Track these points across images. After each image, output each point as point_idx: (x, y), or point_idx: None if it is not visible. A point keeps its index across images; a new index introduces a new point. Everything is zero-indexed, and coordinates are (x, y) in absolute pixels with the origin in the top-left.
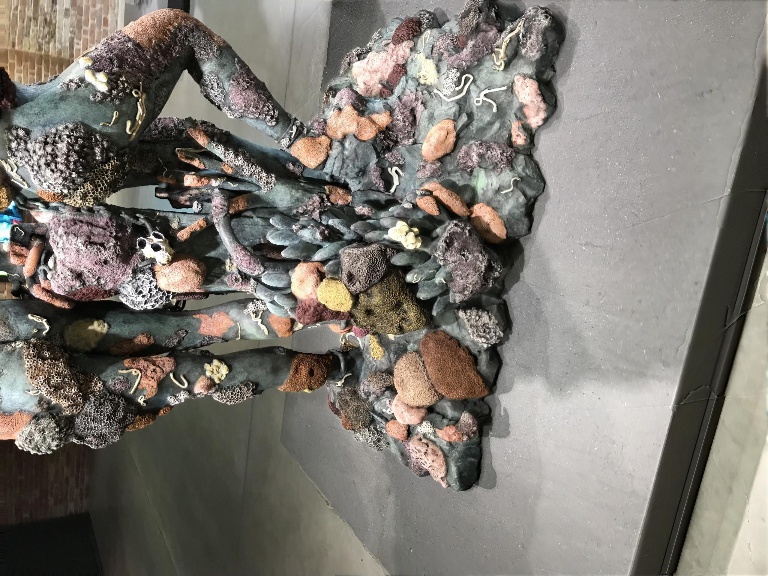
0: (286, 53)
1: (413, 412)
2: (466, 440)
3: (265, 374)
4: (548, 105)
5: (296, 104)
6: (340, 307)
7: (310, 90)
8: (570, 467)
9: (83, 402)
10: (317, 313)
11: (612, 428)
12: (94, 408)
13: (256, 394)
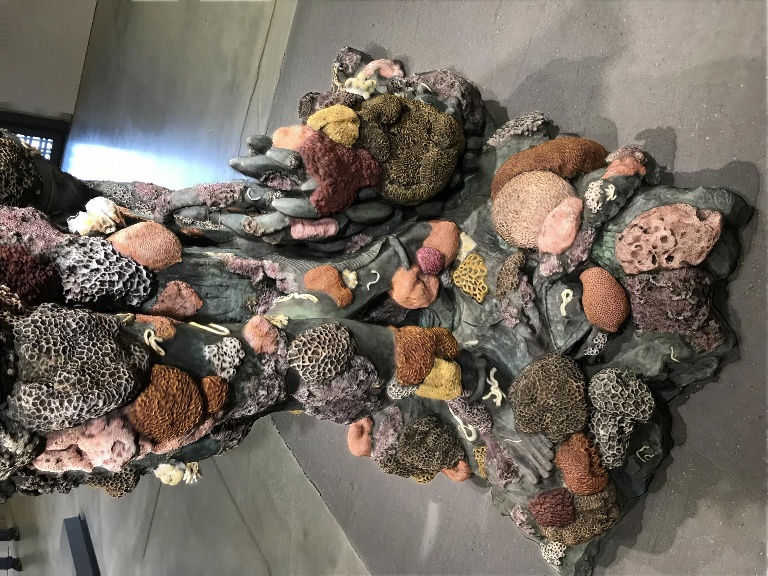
0: (249, 546)
1: (561, 201)
2: (644, 157)
3: (351, 322)
4: (393, 60)
5: (284, 557)
6: (343, 115)
7: (286, 518)
8: (719, 7)
9: (24, 312)
10: (329, 148)
11: None
12: (50, 306)
13: (363, 358)
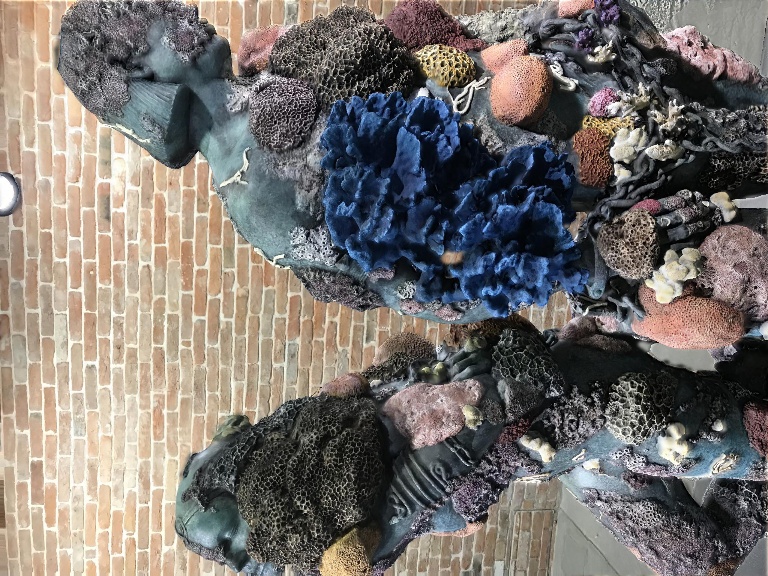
0: None
1: None
2: None
3: None
4: None
5: None
6: None
7: None
8: None
9: None
10: None
11: (767, 195)
12: None
13: None
